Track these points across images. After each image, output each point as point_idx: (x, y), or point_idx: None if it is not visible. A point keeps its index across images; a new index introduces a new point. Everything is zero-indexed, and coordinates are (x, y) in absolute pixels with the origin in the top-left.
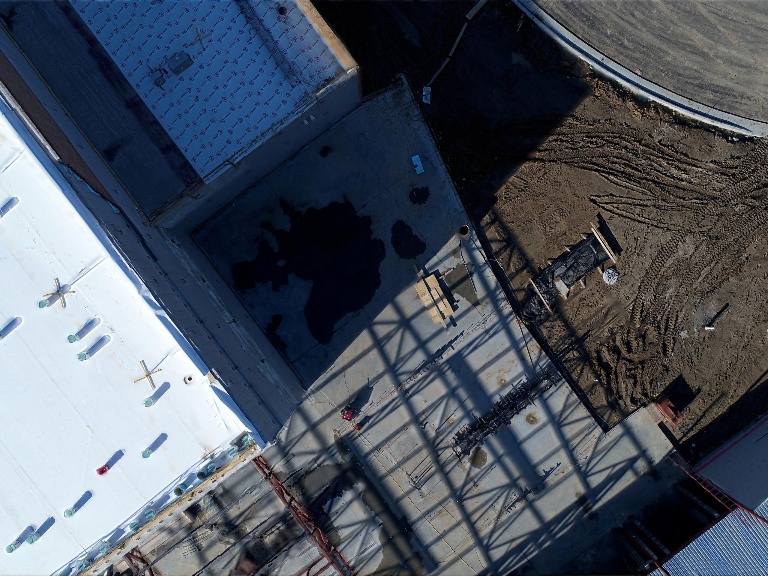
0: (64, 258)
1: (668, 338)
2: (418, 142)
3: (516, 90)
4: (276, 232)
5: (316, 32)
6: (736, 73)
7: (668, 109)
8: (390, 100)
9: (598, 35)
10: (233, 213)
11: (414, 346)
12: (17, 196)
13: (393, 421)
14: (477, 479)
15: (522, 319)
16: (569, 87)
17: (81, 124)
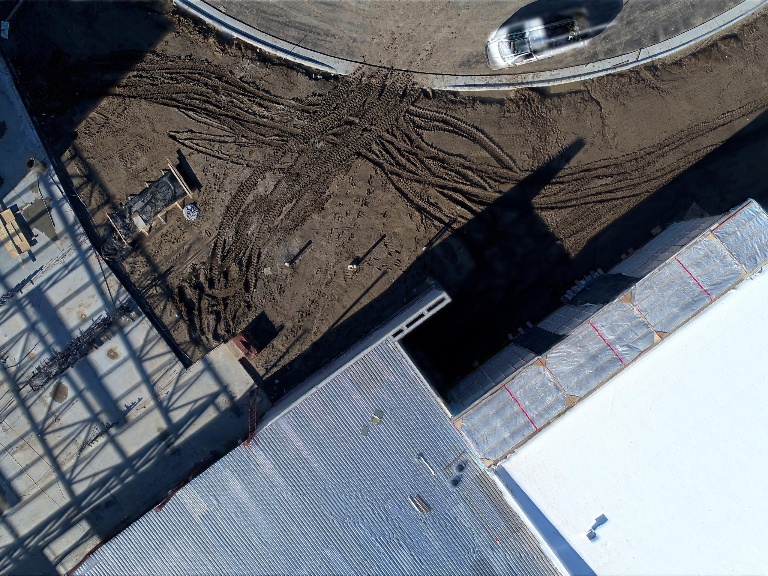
0: None
1: (251, 275)
2: None
3: (96, 26)
4: None
5: None
6: (321, 11)
7: (252, 46)
8: None
9: None
10: None
11: None
12: None
13: None
14: (59, 413)
15: (102, 254)
16: (151, 23)
17: None
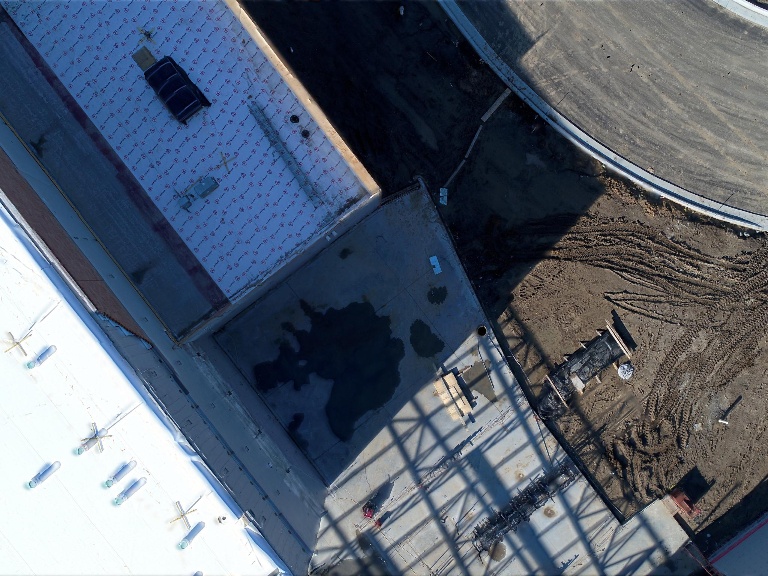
0: (101, 403)
1: (682, 431)
2: (435, 243)
3: (531, 190)
4: (297, 332)
5: (338, 154)
6: (746, 170)
7: (680, 206)
8: (408, 202)
9: (610, 134)
10: (255, 314)
11: (434, 442)
12: (55, 344)
13: (414, 516)
14: (497, 572)
15: (539, 414)
16: (583, 186)
17: (110, 247)
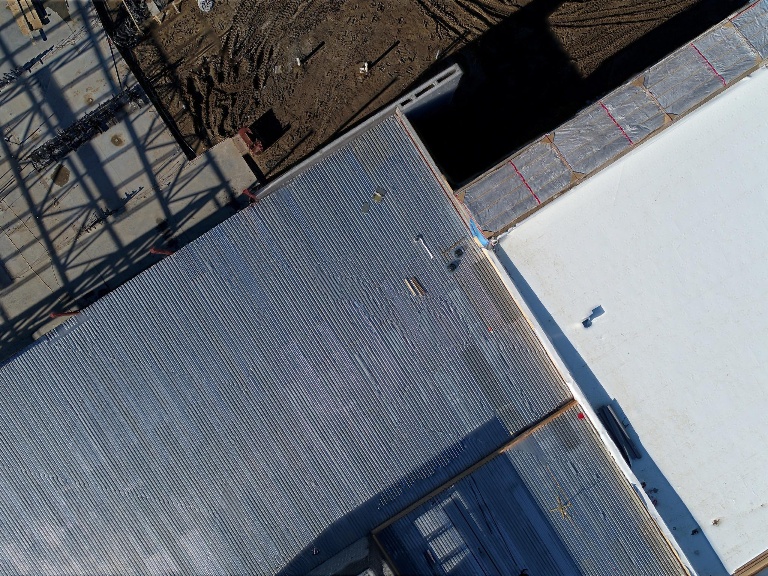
0: None
1: (262, 72)
2: None
3: None
4: None
5: None
6: None
7: None
8: None
9: None
10: None
11: (2, 57)
12: None
13: None
14: (58, 196)
15: (113, 39)
16: None
17: None
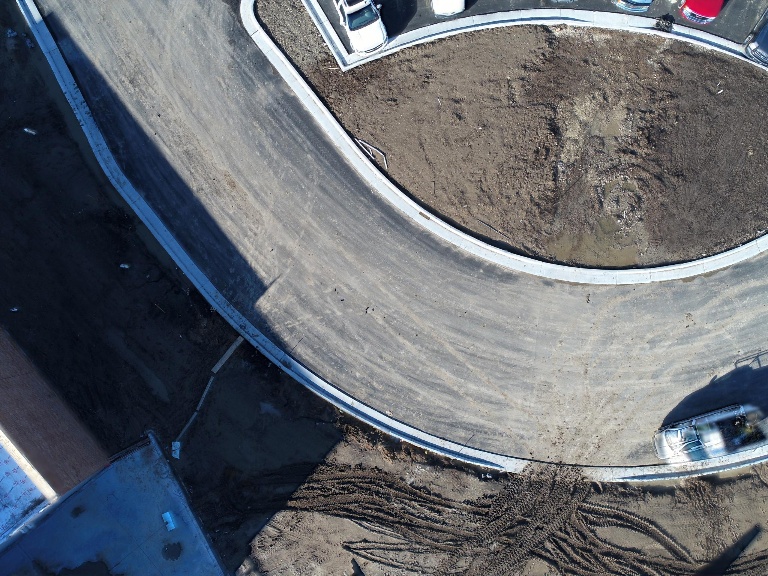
0: None
1: None
2: (168, 499)
3: (265, 440)
4: None
5: None
6: (487, 410)
7: (420, 449)
8: (138, 459)
9: (347, 378)
10: None
11: None
12: None
13: None
14: None
15: None
16: (319, 433)
17: None
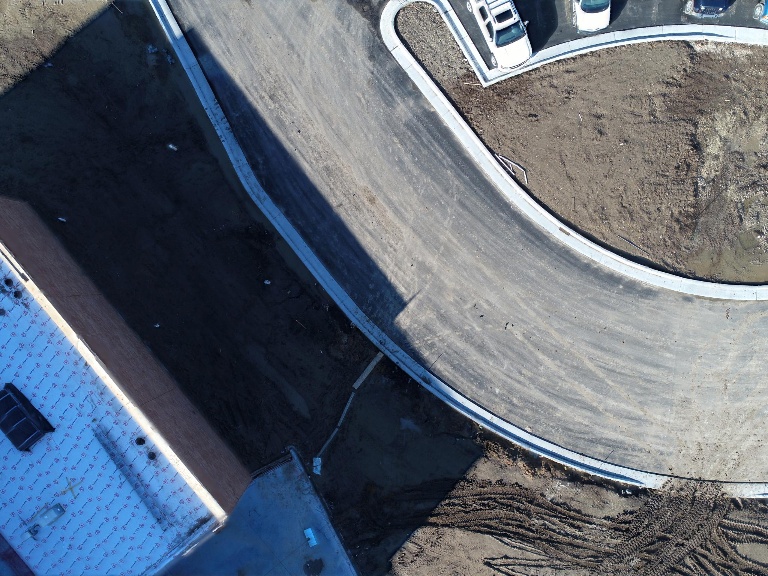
0: None
1: None
2: (310, 515)
3: (406, 456)
4: None
5: None
6: (626, 426)
7: (560, 465)
8: (280, 475)
9: (486, 394)
10: None
11: None
12: None
13: None
14: None
15: None
16: (459, 449)
17: None
